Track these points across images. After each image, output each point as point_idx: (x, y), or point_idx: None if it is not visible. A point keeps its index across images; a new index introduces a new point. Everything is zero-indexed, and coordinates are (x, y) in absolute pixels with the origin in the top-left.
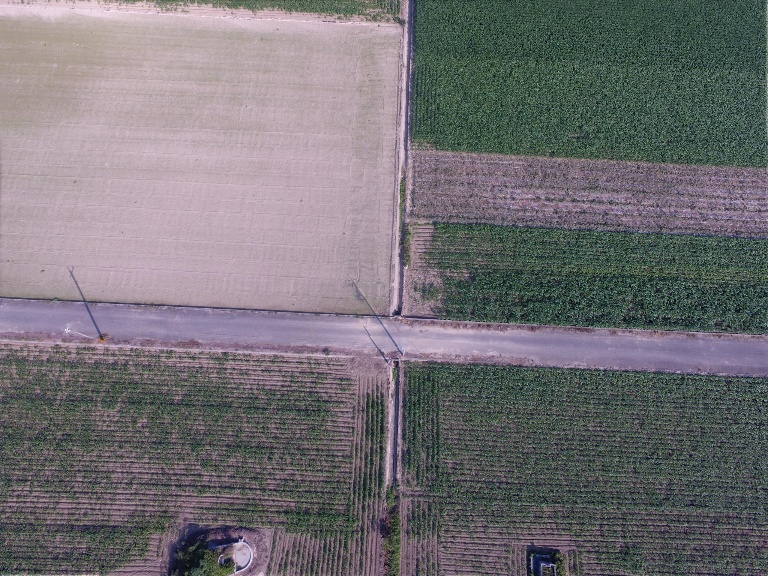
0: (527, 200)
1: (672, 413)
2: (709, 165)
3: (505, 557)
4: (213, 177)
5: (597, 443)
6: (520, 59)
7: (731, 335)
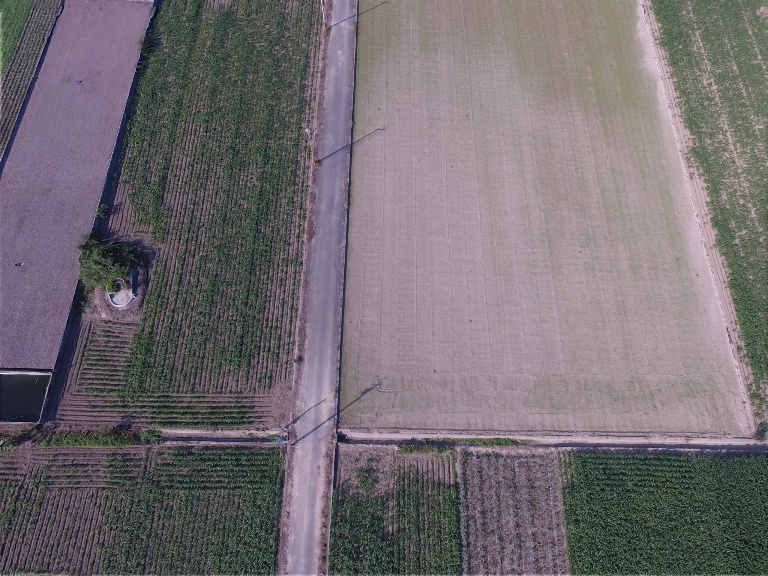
0: None
1: None
2: None
3: (69, 568)
4: (488, 230)
5: None
6: None
7: None
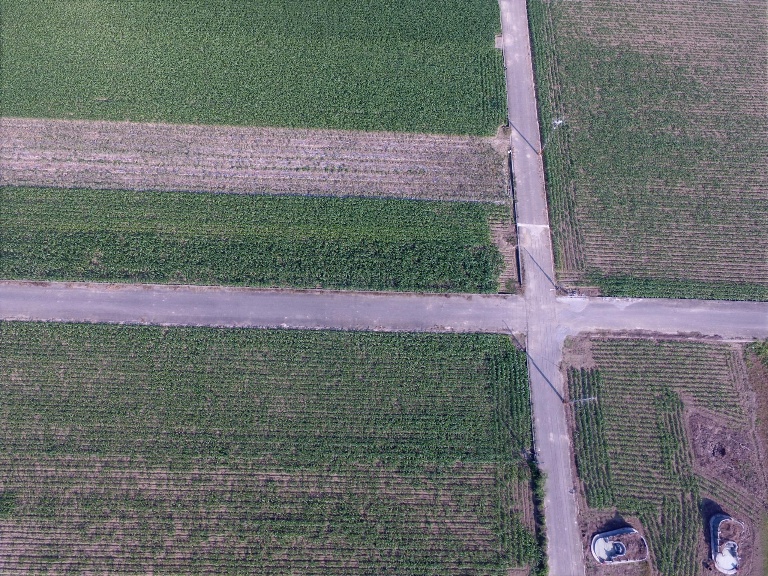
0: (31, 161)
1: (98, 362)
2: (229, 126)
3: None
4: None
5: (11, 392)
6: (69, 27)
7: (188, 286)
